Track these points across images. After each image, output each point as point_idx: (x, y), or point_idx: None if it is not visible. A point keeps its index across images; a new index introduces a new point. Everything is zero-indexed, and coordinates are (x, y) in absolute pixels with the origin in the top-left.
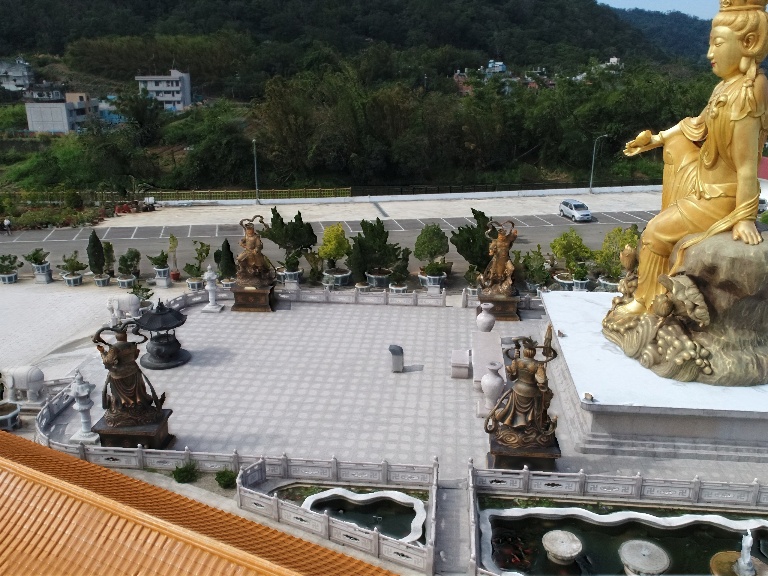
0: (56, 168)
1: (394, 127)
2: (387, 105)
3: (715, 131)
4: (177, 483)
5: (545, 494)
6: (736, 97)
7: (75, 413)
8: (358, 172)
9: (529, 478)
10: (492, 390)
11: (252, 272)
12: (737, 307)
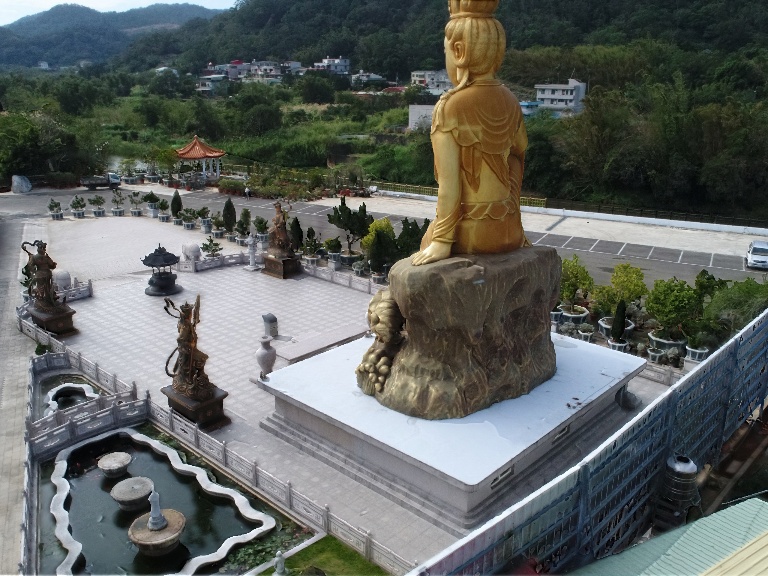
0: (391, 159)
1: (713, 146)
2: (707, 121)
3: None
4: (35, 353)
5: (179, 436)
6: None
7: (69, 305)
8: (660, 191)
9: (172, 419)
10: (258, 359)
11: (277, 243)
12: (416, 331)
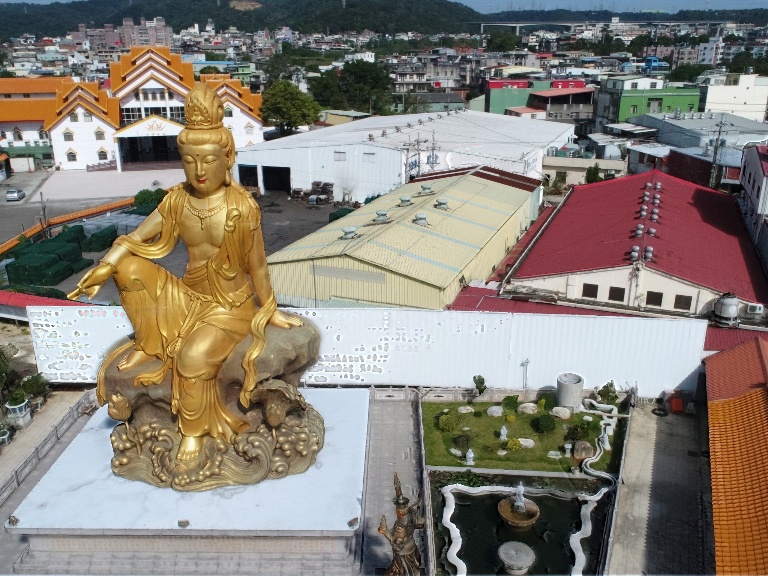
0: None
1: None
2: None
3: (236, 243)
4: None
5: None
6: (250, 209)
7: None
8: None
9: None
10: None
11: None
12: None
